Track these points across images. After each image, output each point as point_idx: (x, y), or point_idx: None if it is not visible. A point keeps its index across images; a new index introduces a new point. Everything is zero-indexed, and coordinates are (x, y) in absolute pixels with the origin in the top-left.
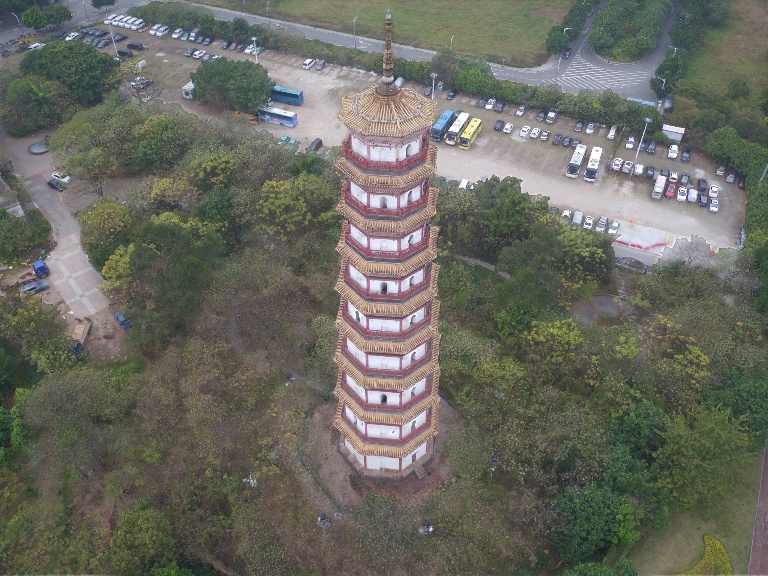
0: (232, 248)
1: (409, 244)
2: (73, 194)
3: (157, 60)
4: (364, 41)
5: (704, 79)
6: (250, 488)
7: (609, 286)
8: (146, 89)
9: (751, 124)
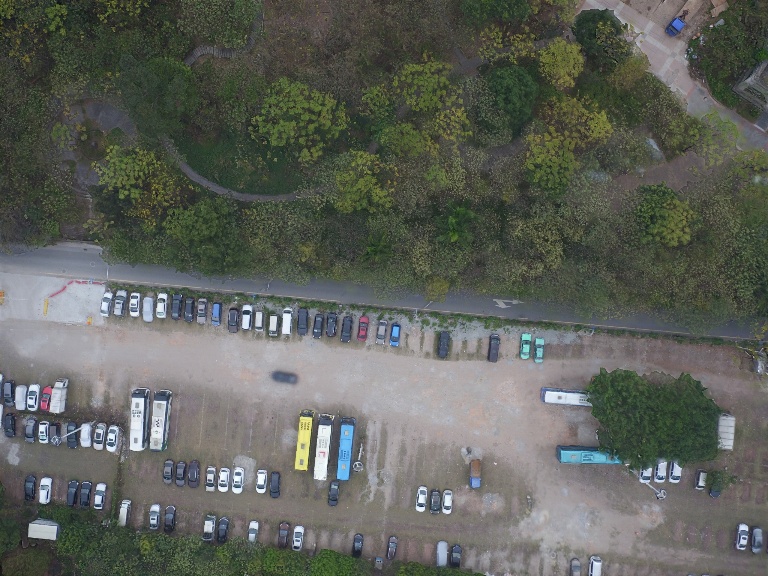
0: None
1: None
2: None
3: None
4: None
5: None
6: None
7: None
8: (764, 358)
9: None
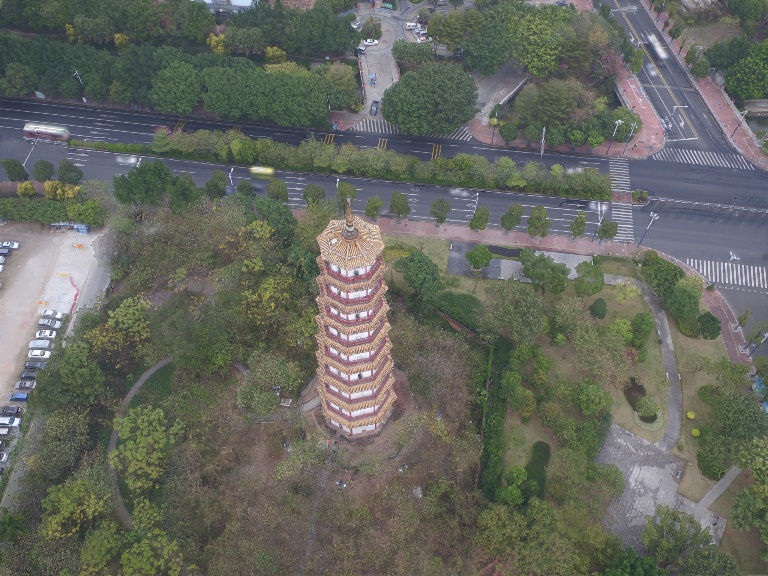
0: None
1: None
2: None
3: None
4: None
5: None
6: None
7: None
8: None
9: None
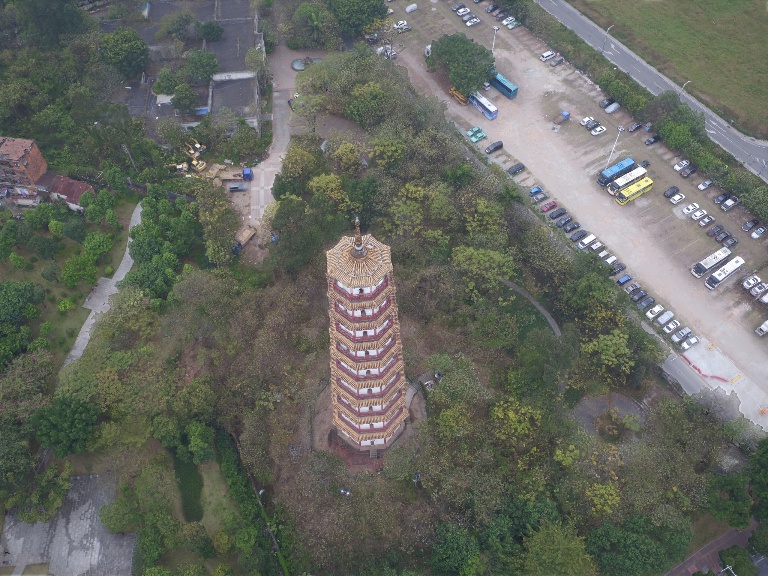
0: (365, 222)
1: (366, 333)
2: (294, 123)
3: (428, 6)
4: (616, 46)
5: None
6: (276, 401)
7: (638, 392)
8: (392, 44)
9: None
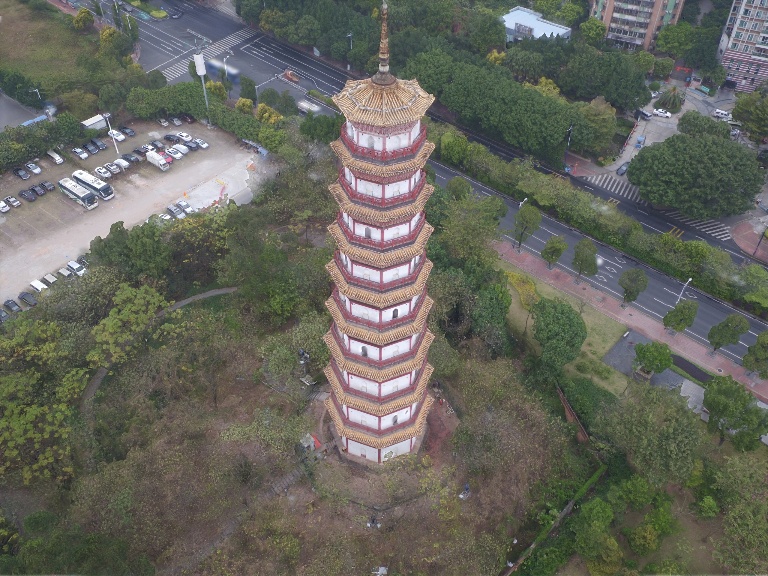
0: None
1: None
2: None
3: None
4: None
5: (33, 78)
6: None
7: None
8: None
9: (139, 78)
